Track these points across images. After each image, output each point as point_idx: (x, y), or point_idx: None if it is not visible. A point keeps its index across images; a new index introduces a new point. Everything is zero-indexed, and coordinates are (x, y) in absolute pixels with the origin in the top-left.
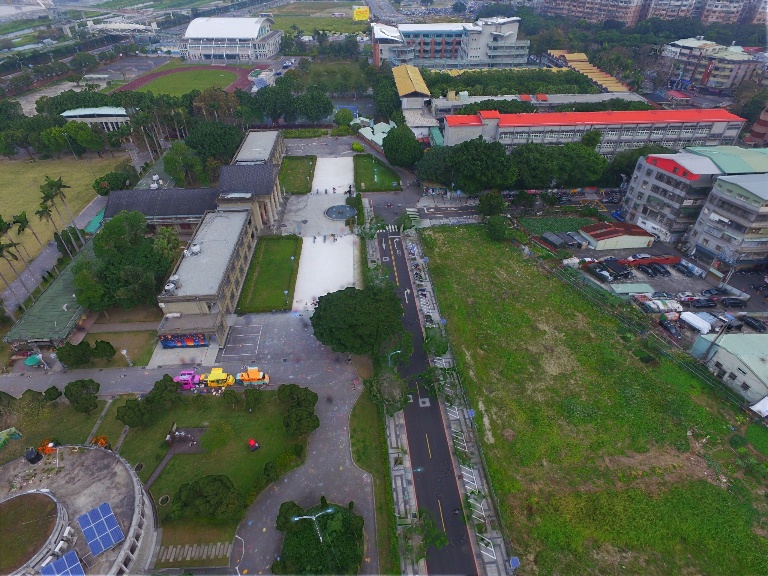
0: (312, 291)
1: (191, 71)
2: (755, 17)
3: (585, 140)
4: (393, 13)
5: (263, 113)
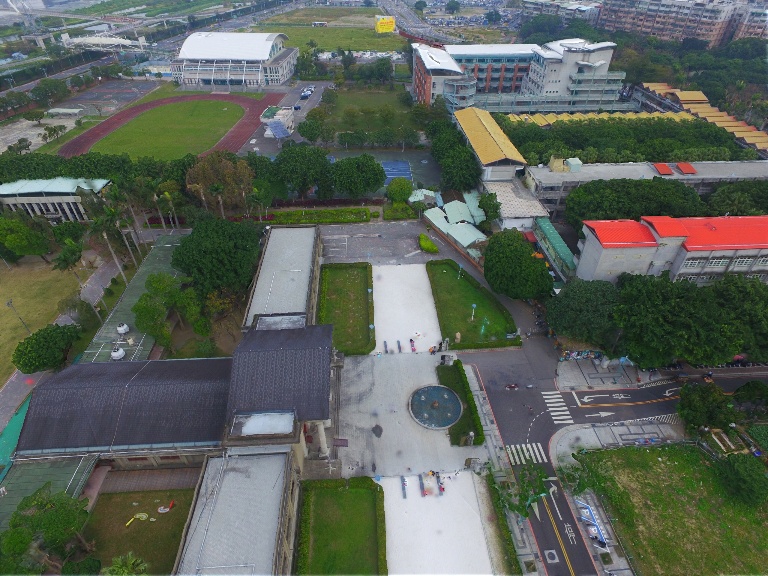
0: None
1: (186, 102)
2: None
3: None
4: (418, 22)
5: (287, 186)
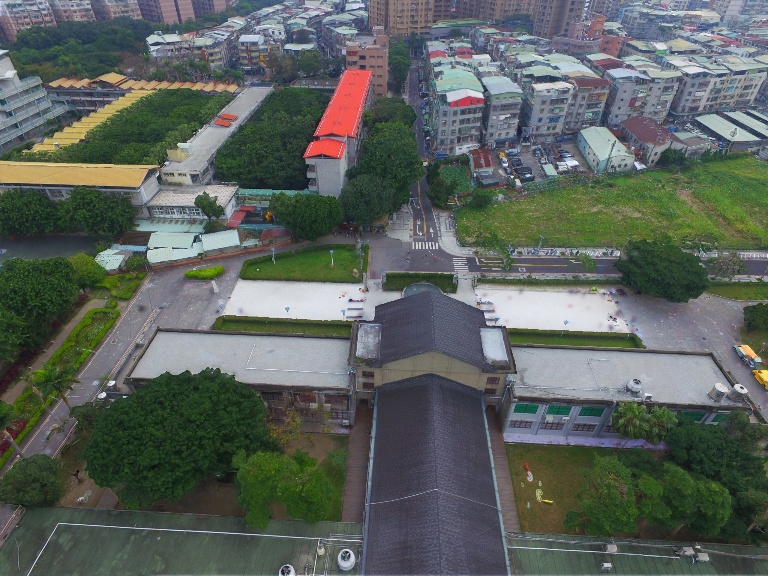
0: (593, 322)
1: None
2: (110, 11)
3: (369, 121)
4: None
5: None
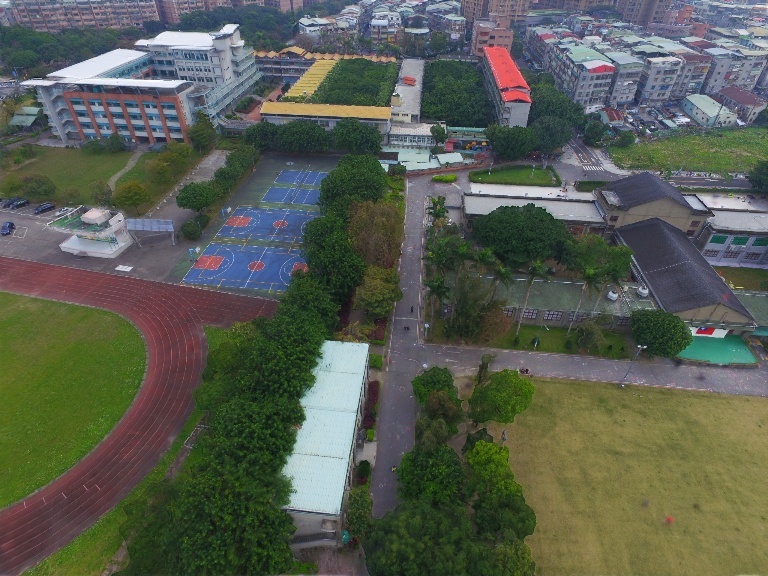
0: None
1: None
2: None
3: None
4: None
5: None
